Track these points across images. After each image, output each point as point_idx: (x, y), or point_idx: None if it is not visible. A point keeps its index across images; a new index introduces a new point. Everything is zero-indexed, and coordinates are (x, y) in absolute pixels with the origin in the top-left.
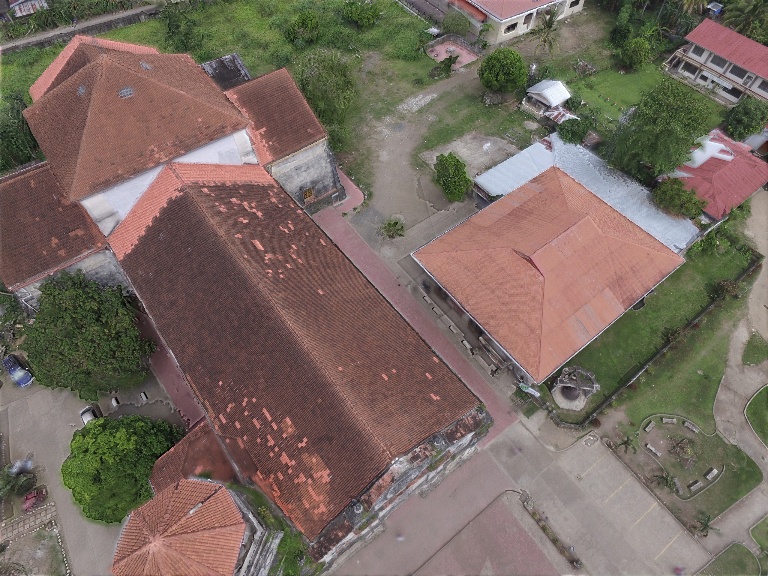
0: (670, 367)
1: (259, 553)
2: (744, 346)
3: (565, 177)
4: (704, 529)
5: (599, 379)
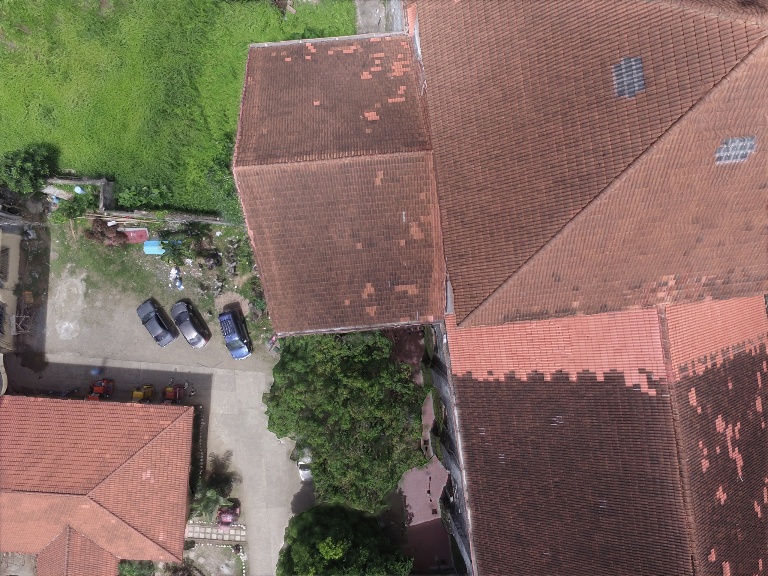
0: None
1: None
2: None
3: None
4: None
5: None
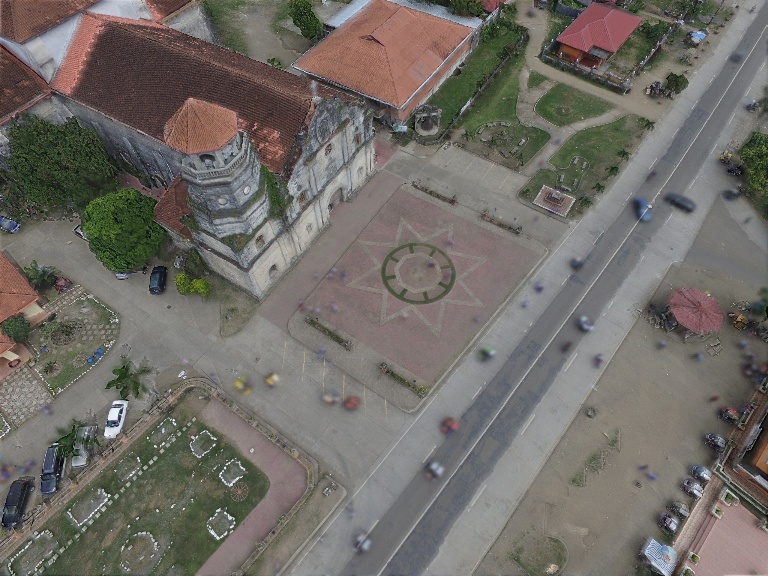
0: (486, 100)
1: (249, 153)
2: (527, 79)
3: (384, 1)
4: (519, 159)
5: (443, 116)
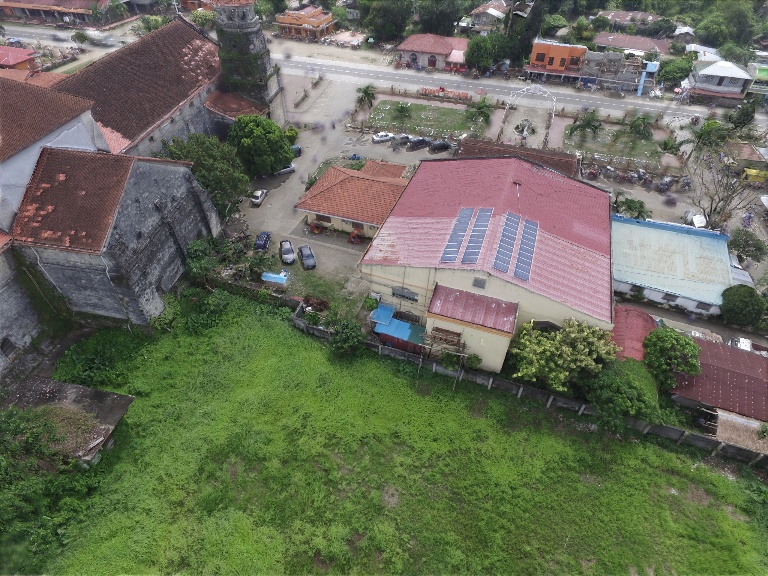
0: None
1: None
2: None
3: None
4: None
5: None
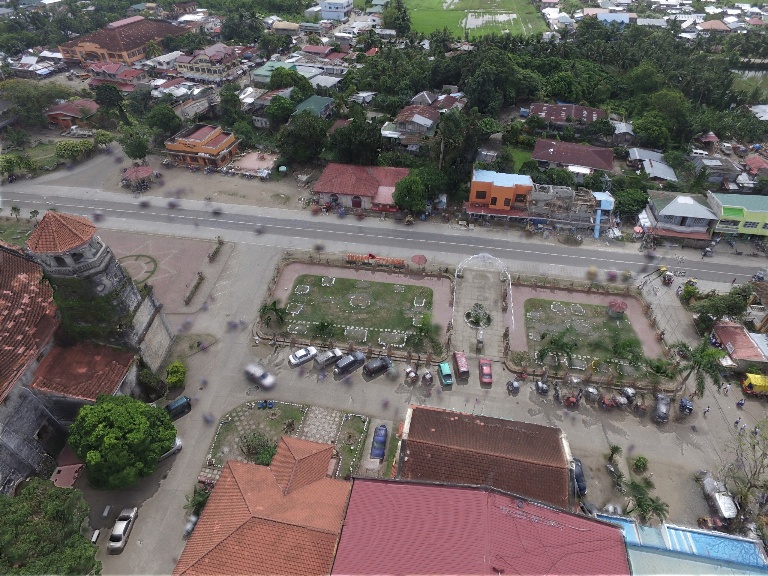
0: None
1: None
2: None
3: None
4: None
5: None
